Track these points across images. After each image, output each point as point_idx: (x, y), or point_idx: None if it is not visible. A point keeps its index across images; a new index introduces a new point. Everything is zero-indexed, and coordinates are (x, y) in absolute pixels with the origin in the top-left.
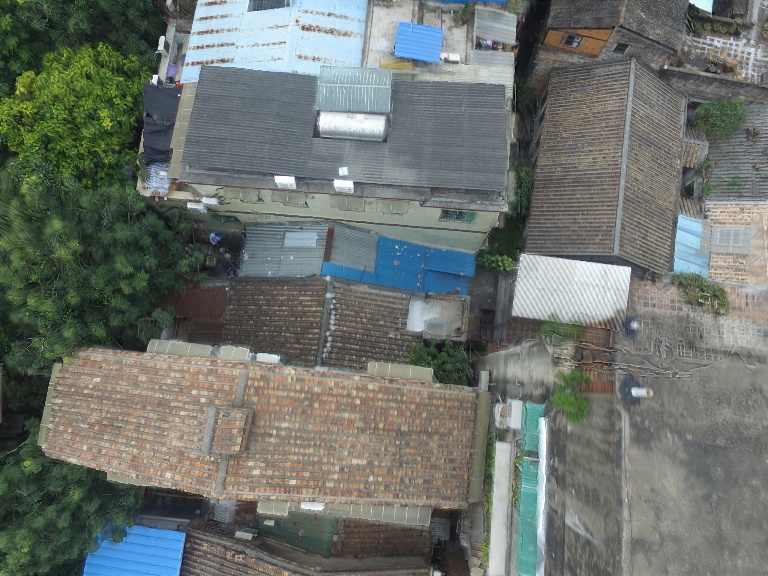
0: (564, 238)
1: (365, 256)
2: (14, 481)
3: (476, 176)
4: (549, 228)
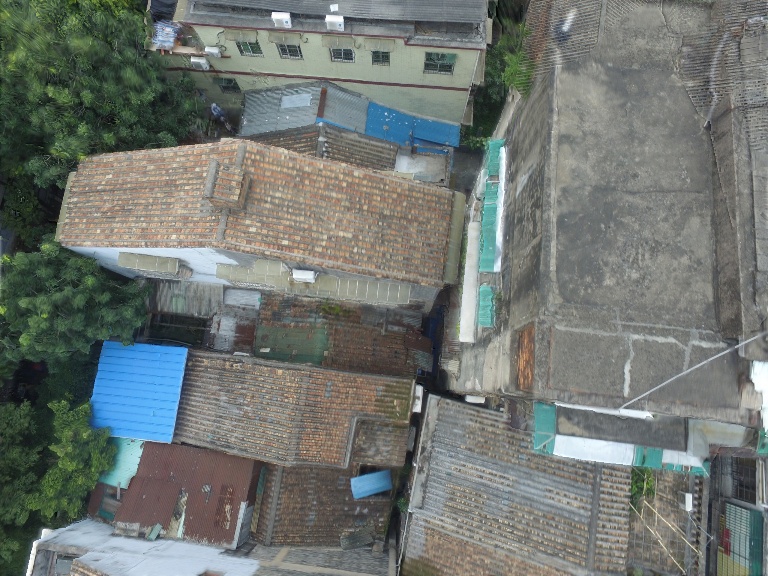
0: None
1: (356, 118)
2: (34, 262)
3: (456, 10)
4: None
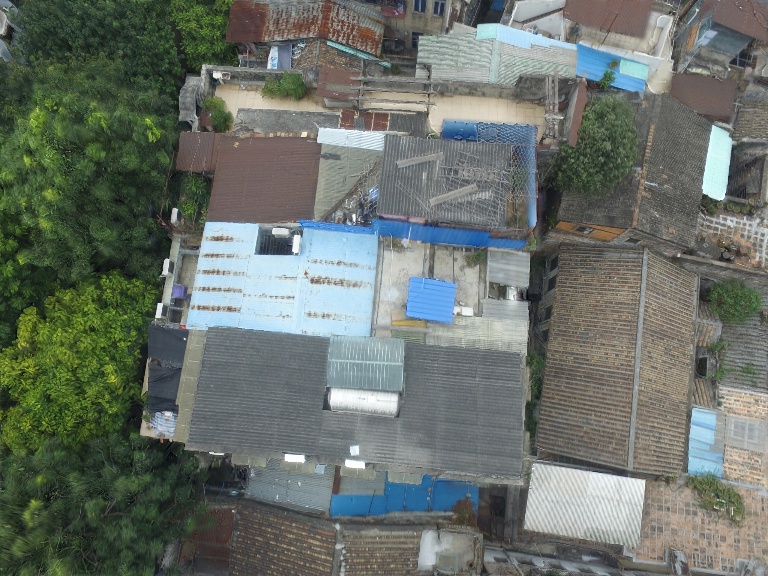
0: (576, 439)
1: None
2: None
3: (491, 460)
4: (561, 424)
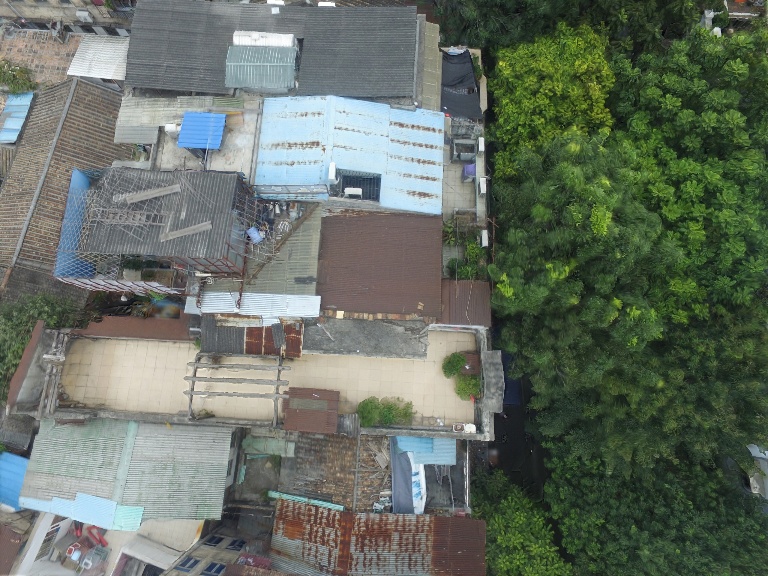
0: None
1: None
2: None
3: (161, 7)
4: None
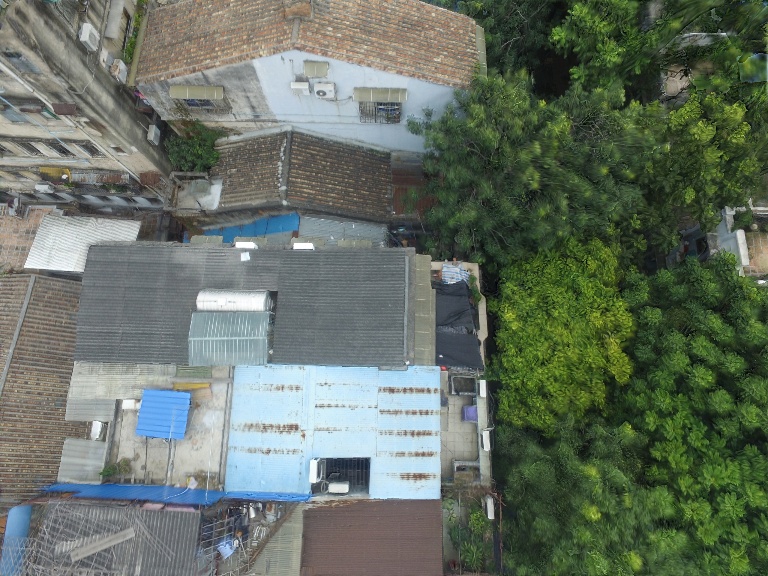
0: None
1: None
2: None
3: (115, 257)
4: None
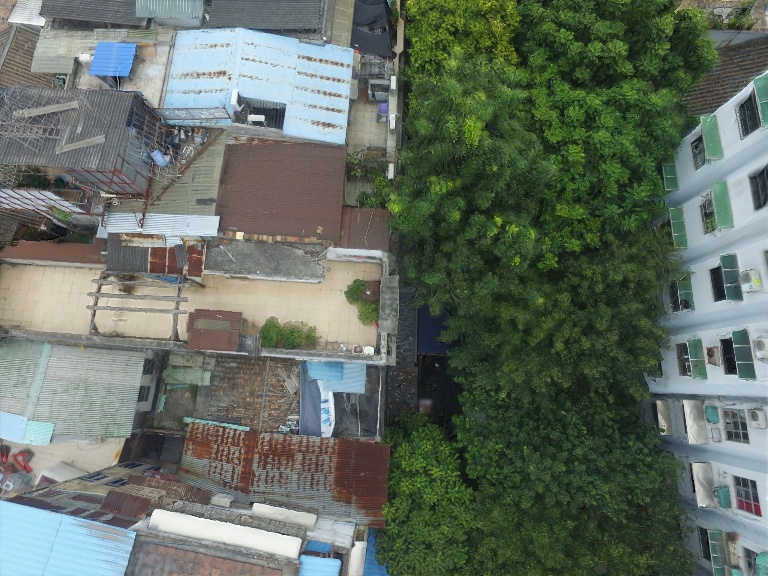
0: None
1: None
2: None
3: None
4: None
